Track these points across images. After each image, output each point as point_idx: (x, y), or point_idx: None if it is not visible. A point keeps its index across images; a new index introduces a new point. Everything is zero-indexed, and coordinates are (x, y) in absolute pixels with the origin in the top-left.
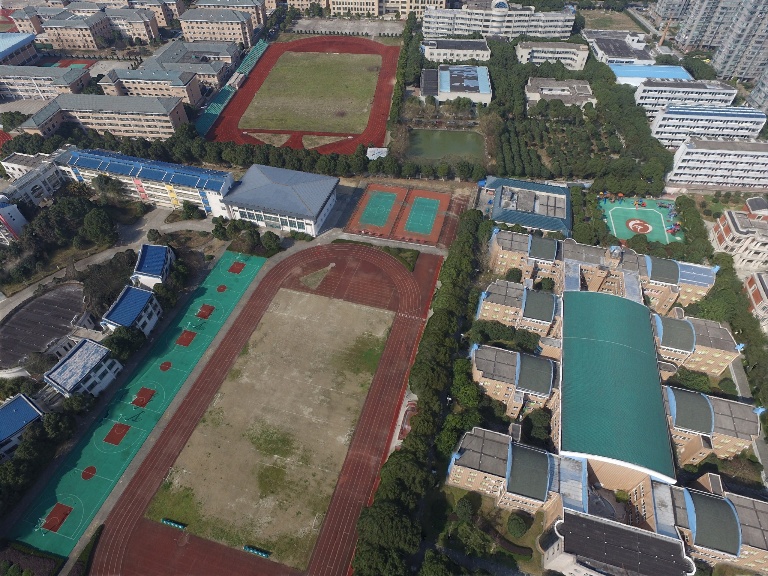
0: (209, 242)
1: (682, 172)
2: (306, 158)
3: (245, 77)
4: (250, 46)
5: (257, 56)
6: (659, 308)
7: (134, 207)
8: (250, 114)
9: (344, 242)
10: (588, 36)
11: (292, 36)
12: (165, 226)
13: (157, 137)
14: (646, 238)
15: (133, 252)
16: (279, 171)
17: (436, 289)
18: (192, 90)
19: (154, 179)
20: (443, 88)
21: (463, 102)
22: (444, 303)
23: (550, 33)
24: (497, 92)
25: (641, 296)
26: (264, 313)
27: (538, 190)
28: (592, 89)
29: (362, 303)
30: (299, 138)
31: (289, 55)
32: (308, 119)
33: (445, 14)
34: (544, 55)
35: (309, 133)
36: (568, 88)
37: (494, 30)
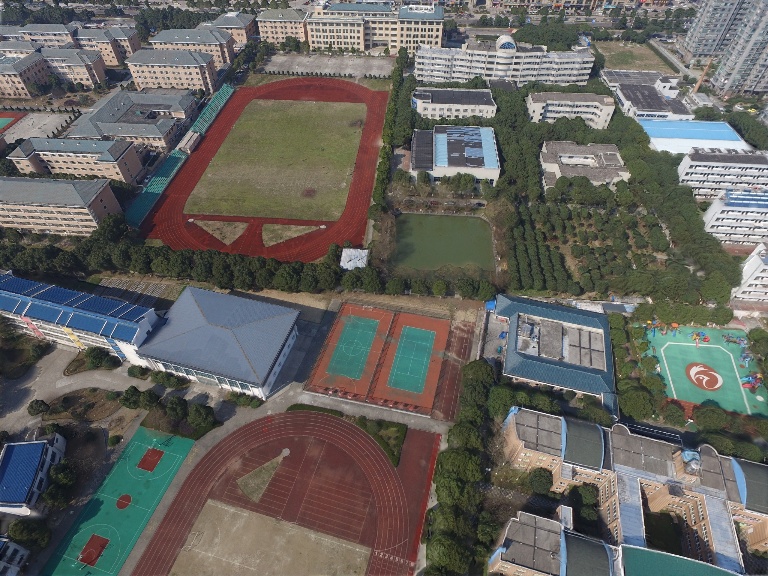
0: (118, 410)
1: (753, 290)
2: (260, 271)
3: (201, 136)
4: (212, 92)
5: (218, 107)
6: (756, 544)
7: (27, 347)
8: (201, 191)
9: (304, 409)
10: (609, 79)
11: (263, 78)
12: (63, 381)
13: (77, 231)
14: (724, 416)
15: (5, 437)
16: (220, 300)
17: (430, 500)
18: (127, 163)
19: (45, 320)
20: (439, 160)
21: (464, 180)
22: (442, 558)
23: (565, 76)
24: (506, 165)
25: (737, 547)
26: (179, 552)
27: (566, 321)
28: (623, 158)
29: (323, 530)
30: (258, 229)
31: (257, 104)
32: (272, 199)
33: (441, 55)
34: (561, 109)
35: (271, 221)
36: (593, 156)
37: (499, 73)
